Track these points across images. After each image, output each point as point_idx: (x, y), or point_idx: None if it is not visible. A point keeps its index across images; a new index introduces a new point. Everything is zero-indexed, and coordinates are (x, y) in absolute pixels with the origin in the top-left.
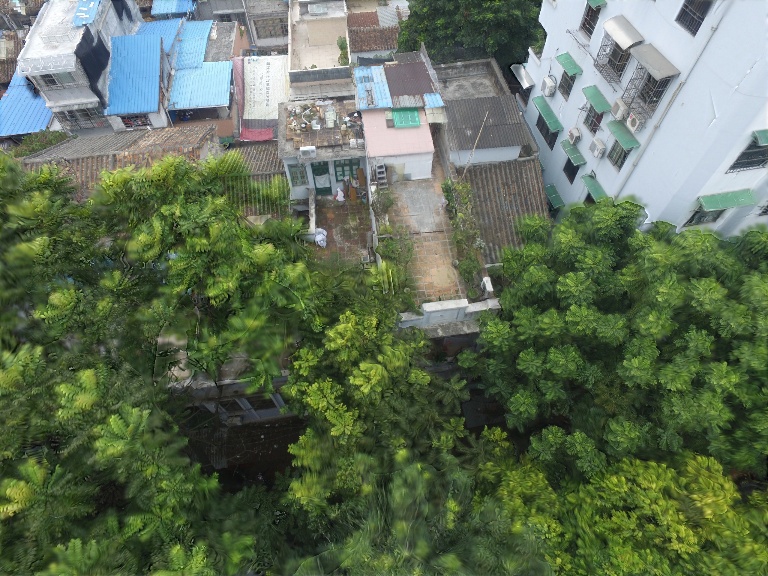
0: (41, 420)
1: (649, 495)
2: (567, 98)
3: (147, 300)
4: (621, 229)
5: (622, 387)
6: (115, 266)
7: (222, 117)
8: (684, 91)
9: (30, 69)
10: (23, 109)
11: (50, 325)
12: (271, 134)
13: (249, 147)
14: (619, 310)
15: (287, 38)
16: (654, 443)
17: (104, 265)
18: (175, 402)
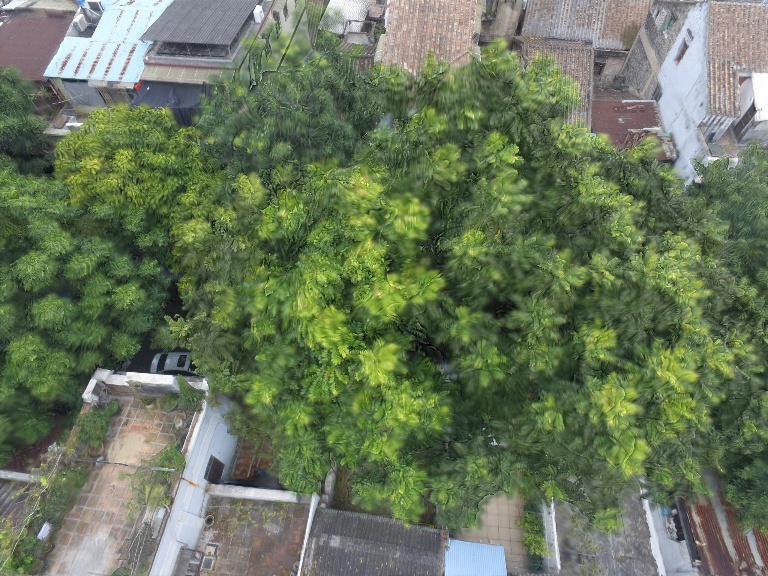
0: None
1: (118, 170)
2: None
3: (363, 161)
4: None
5: (71, 227)
6: None
7: None
8: None
9: None
10: None
11: None
12: None
13: None
14: None
15: None
16: None
17: None
18: None
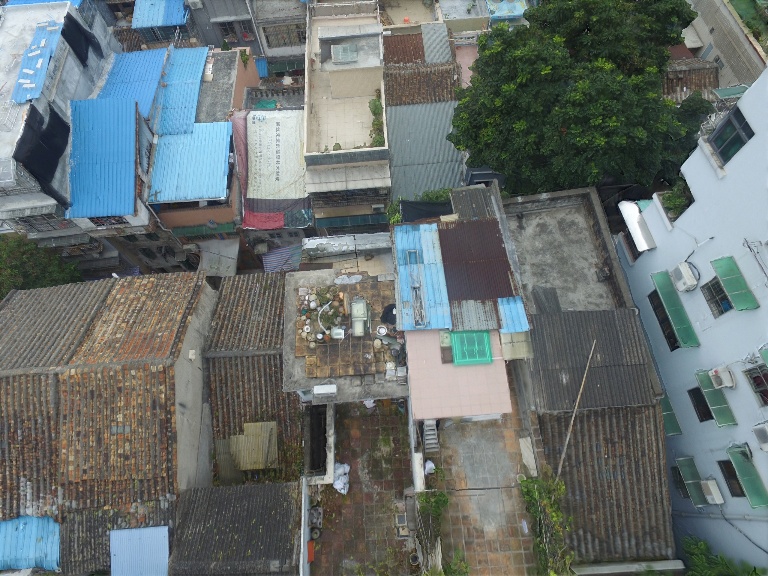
0: None
1: None
2: (716, 313)
3: None
4: None
5: None
6: None
7: None
8: None
9: None
10: None
11: None
12: (282, 220)
13: (251, 275)
14: None
15: None
16: None
17: None
18: None
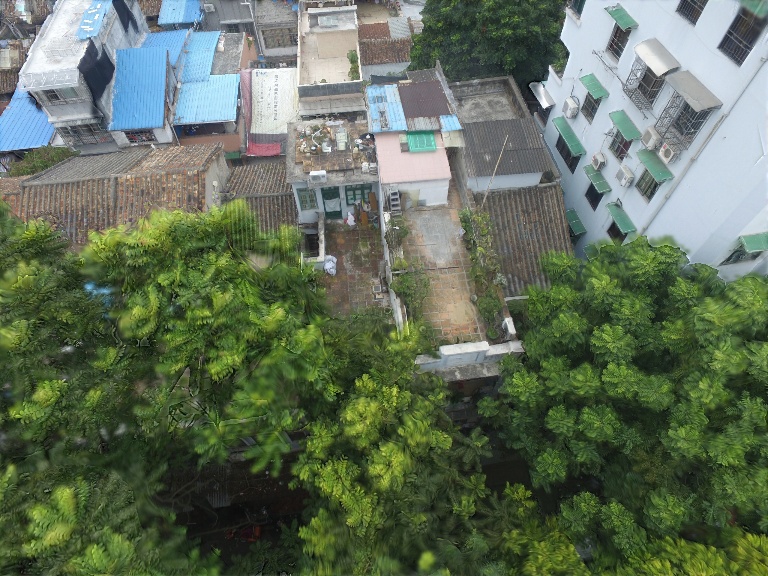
0: (11, 550)
1: None
2: (591, 121)
3: (141, 383)
4: (660, 276)
5: (664, 455)
6: (106, 342)
7: (229, 132)
8: (727, 124)
9: (32, 84)
10: (25, 123)
11: (27, 425)
12: (279, 149)
13: (256, 165)
14: (658, 366)
15: (296, 48)
16: (699, 517)
17: (93, 342)
18: (175, 446)
